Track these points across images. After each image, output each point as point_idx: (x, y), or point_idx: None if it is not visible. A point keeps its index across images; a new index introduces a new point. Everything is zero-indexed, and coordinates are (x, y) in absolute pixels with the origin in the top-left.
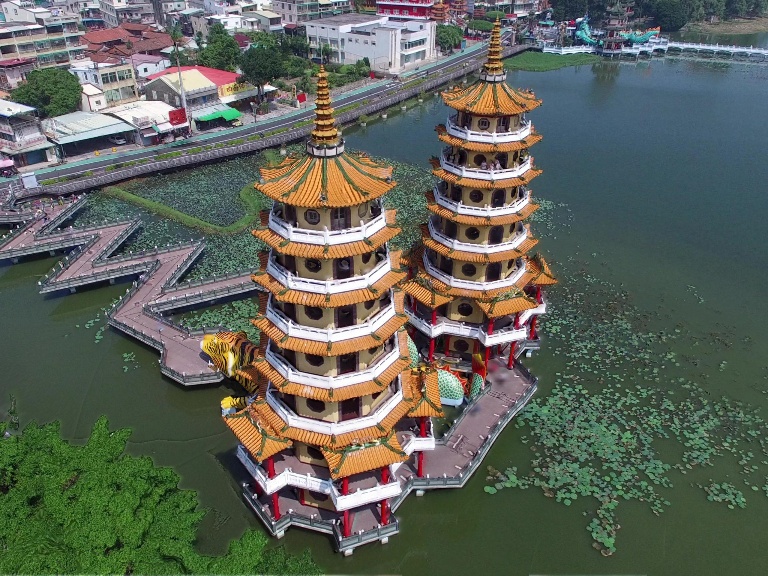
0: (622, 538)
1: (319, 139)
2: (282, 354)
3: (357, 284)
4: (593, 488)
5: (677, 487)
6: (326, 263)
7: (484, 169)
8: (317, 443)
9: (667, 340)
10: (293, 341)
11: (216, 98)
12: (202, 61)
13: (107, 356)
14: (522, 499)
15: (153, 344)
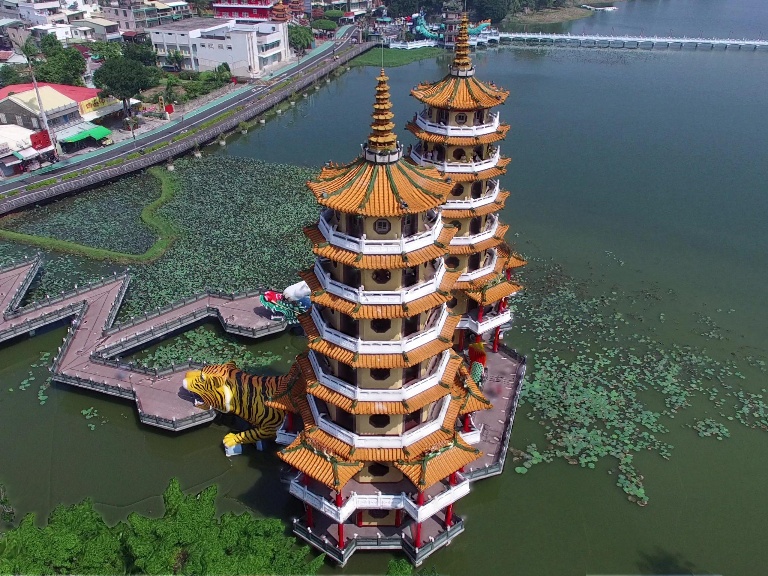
0: (649, 487)
1: (380, 145)
2: (335, 375)
3: (426, 289)
4: (607, 448)
5: (672, 431)
6: (396, 272)
7: (465, 162)
8: (390, 459)
9: (610, 303)
10: (364, 358)
11: (78, 116)
12: (43, 77)
13: (59, 417)
14: (552, 472)
15: (119, 393)
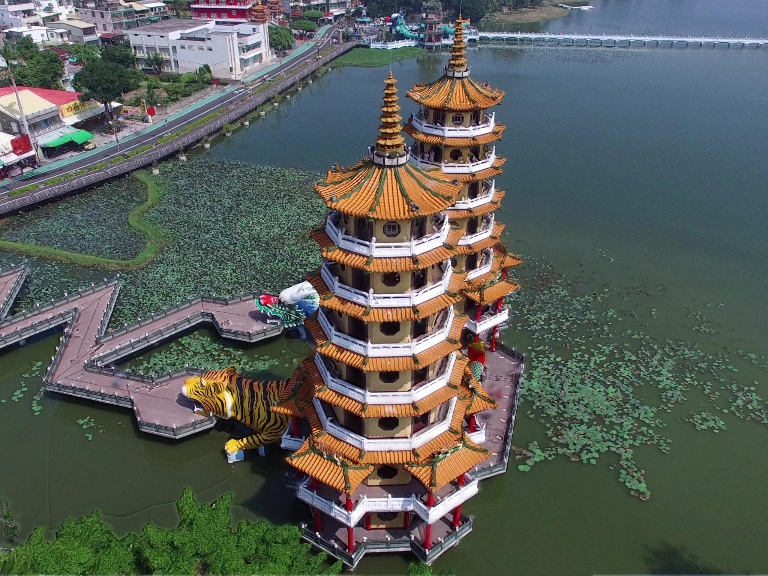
0: (650, 481)
1: (389, 148)
2: (343, 379)
3: (435, 291)
4: (607, 443)
5: (670, 425)
6: (405, 275)
7: (462, 163)
8: (400, 461)
9: (602, 299)
10: (374, 362)
11: (59, 120)
12: (20, 80)
13: (55, 428)
14: (555, 469)
15: (116, 402)
